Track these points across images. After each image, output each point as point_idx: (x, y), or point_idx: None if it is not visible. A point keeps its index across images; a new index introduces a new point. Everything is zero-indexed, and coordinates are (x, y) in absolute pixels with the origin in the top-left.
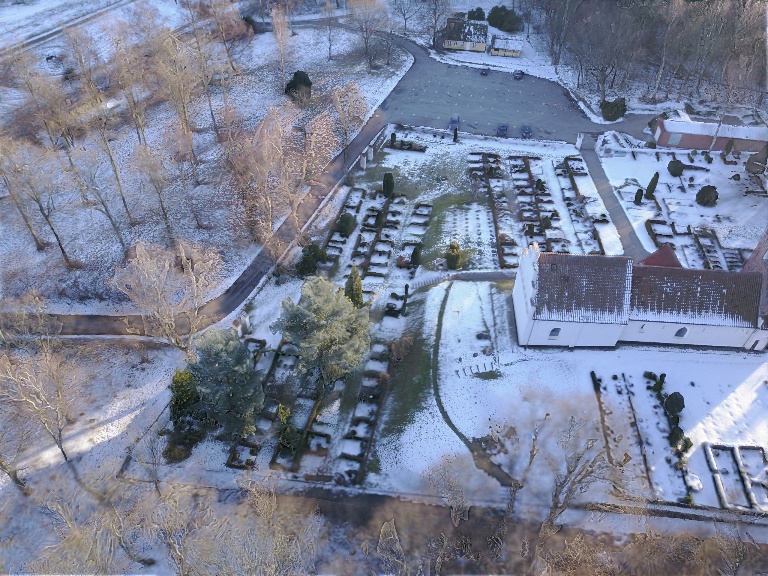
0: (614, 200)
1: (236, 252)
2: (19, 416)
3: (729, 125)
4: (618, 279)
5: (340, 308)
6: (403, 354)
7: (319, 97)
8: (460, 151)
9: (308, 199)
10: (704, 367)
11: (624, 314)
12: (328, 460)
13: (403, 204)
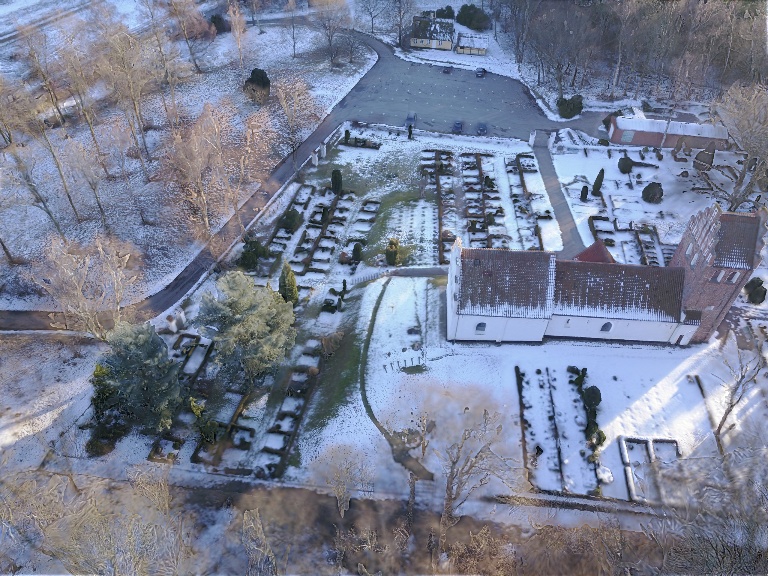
0: (561, 197)
1: (179, 248)
2: None
3: (682, 122)
4: (541, 274)
5: (257, 302)
6: (333, 349)
7: None
8: (414, 148)
9: (257, 196)
10: (628, 362)
11: (547, 309)
12: (250, 454)
13: (351, 201)
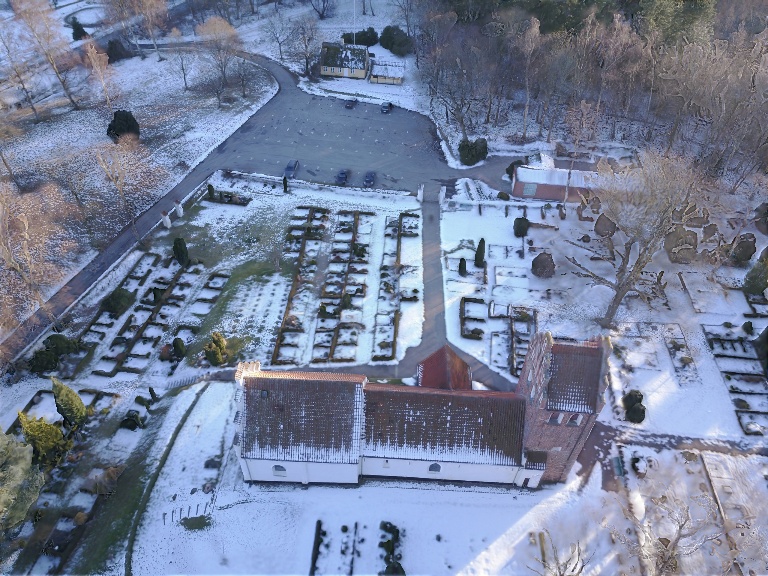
0: (437, 269)
1: None
2: None
3: (593, 172)
4: (344, 408)
5: None
6: (106, 490)
7: (152, 137)
8: (287, 204)
9: (90, 268)
10: (460, 512)
11: (353, 451)
12: None
13: (197, 274)
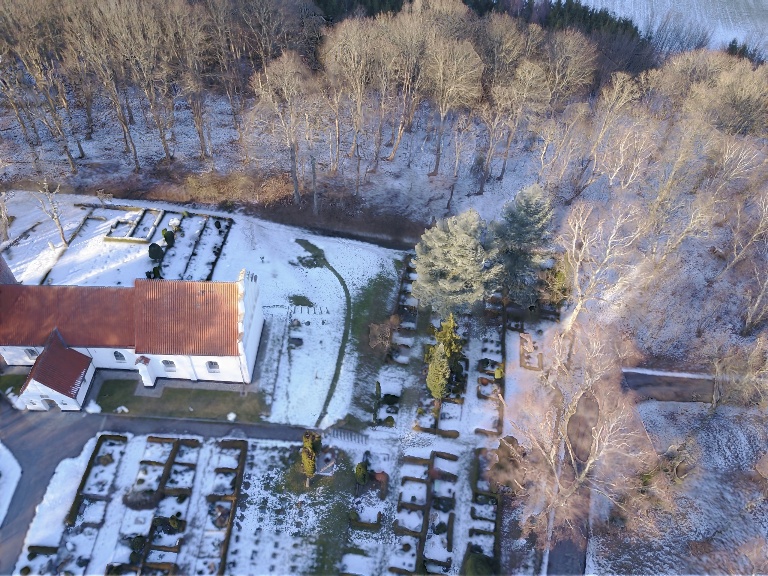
0: None
1: None
2: (688, 288)
3: None
4: None
5: None
6: None
7: None
8: None
9: None
10: None
11: None
12: None
13: None
